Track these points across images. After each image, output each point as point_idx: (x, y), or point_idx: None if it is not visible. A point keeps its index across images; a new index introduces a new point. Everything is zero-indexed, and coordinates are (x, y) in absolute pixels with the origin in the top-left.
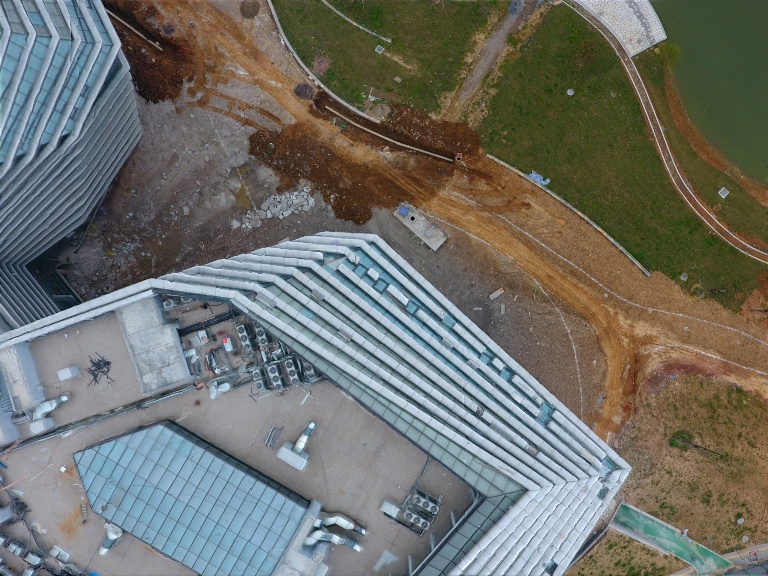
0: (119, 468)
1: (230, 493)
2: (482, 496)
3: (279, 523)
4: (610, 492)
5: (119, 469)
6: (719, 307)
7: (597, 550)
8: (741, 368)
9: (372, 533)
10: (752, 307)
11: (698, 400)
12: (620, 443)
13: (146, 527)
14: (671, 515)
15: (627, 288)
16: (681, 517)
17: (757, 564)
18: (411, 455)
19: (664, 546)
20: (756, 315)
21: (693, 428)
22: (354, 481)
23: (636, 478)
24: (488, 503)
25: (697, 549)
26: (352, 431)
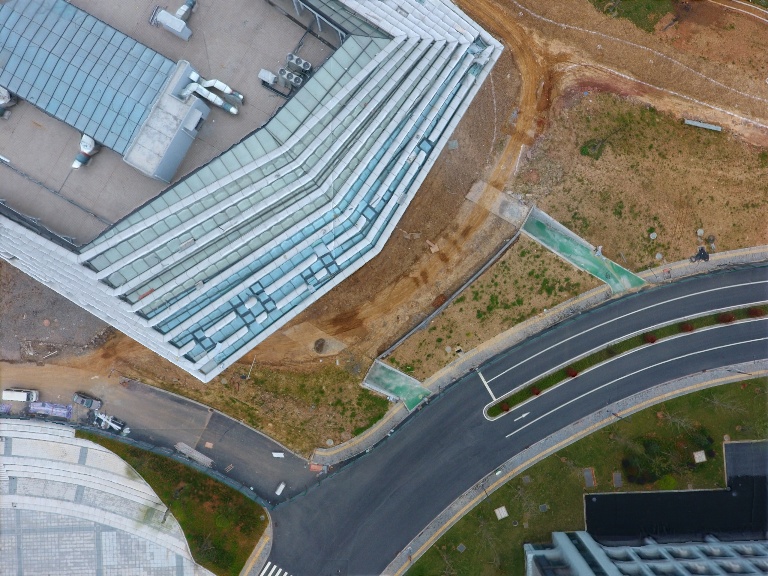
0: (5, 30)
1: (111, 53)
2: (347, 32)
3: (158, 80)
4: (483, 71)
5: (5, 31)
6: (632, 26)
7: (509, 255)
8: (655, 89)
9: (252, 106)
10: (664, 26)
11: (611, 115)
12: (533, 155)
13: (31, 86)
14: (584, 228)
15: (540, 3)
16: (594, 231)
17: (671, 282)
18: (290, 32)
19: (579, 264)
20: (669, 35)
21: (604, 138)
22: (235, 56)
23: (548, 186)
24: (353, 41)
25: (611, 267)
26: (233, 10)
